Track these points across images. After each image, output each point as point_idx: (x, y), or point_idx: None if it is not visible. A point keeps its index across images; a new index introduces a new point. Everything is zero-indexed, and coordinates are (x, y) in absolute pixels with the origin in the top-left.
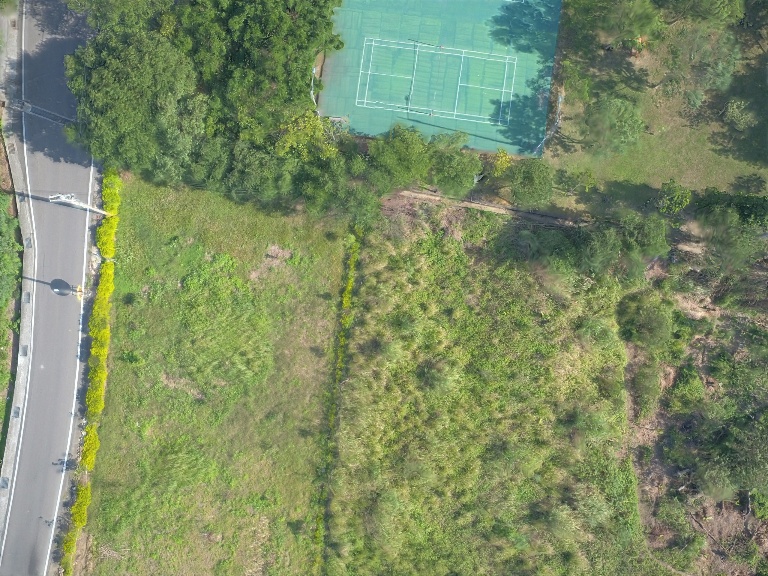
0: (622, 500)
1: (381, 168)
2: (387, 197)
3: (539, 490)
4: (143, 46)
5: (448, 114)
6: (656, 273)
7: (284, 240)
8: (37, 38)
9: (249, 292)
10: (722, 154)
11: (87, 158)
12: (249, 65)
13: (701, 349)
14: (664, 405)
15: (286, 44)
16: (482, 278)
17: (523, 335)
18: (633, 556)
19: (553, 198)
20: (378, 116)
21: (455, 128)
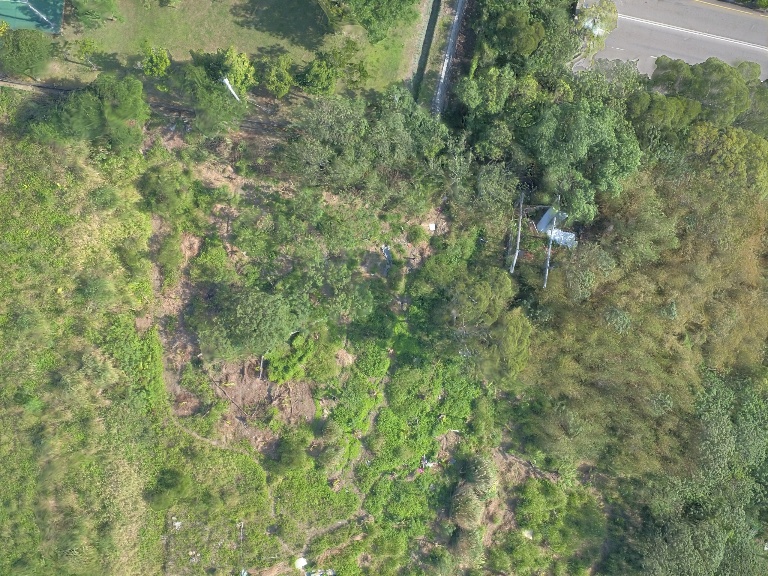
0: (132, 365)
1: None
2: None
3: (59, 359)
4: None
5: None
6: (178, 144)
7: None
8: None
9: None
10: (244, 25)
11: None
12: None
13: (224, 218)
14: (188, 274)
15: None
16: (6, 153)
17: (43, 207)
18: (155, 423)
19: (78, 74)
20: None
21: None
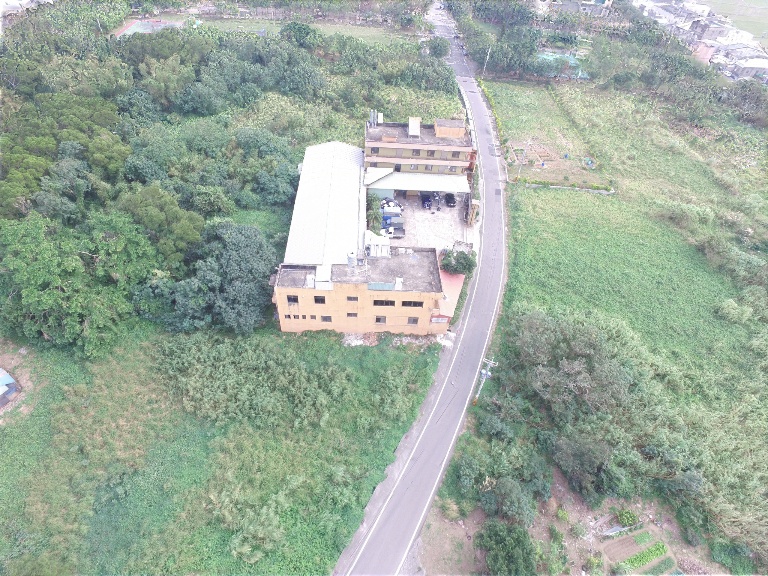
0: None
1: None
2: (554, 85)
3: None
4: None
5: None
6: None
7: (530, 90)
8: None
9: None
10: None
11: None
12: None
13: None
14: None
15: None
16: None
17: None
18: None
19: None
20: None
21: None
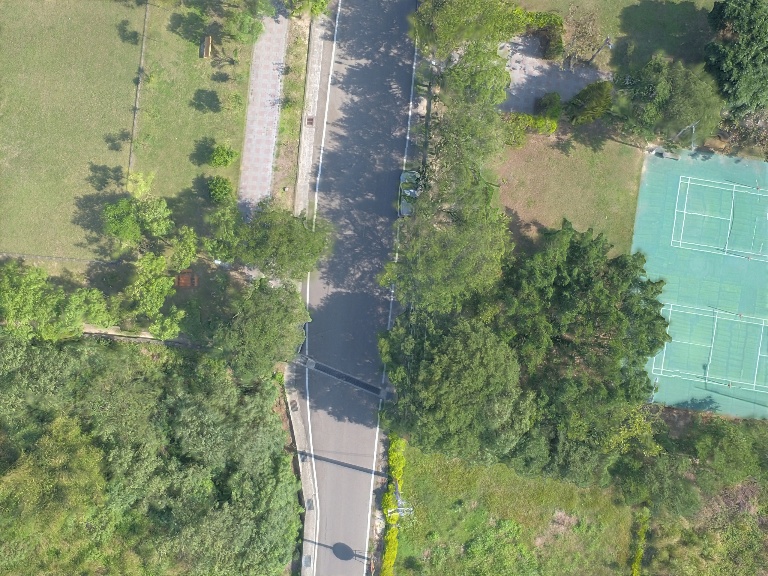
0: None
1: (716, 476)
2: None
3: None
4: (473, 343)
5: (747, 386)
6: None
7: (572, 507)
8: (322, 292)
9: (535, 560)
10: None
11: (373, 419)
12: (579, 363)
13: None
14: None
15: (627, 350)
16: None
17: None
18: None
19: None
20: (675, 385)
21: (755, 401)
